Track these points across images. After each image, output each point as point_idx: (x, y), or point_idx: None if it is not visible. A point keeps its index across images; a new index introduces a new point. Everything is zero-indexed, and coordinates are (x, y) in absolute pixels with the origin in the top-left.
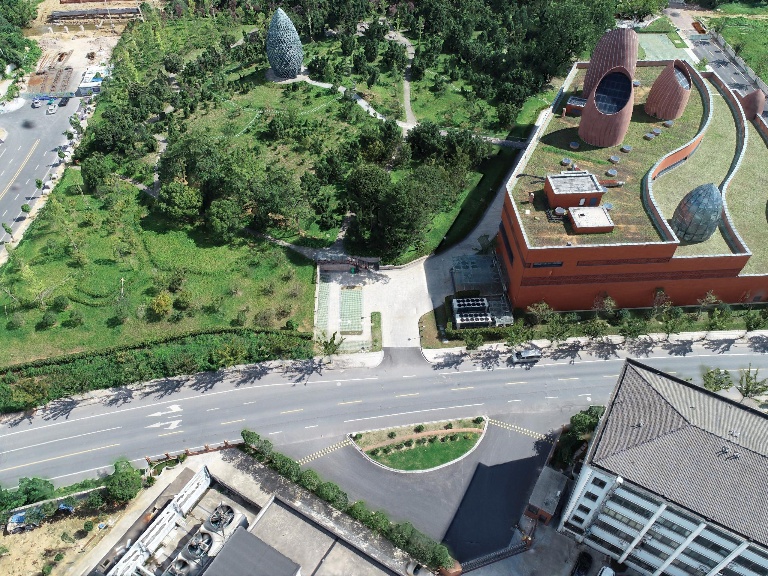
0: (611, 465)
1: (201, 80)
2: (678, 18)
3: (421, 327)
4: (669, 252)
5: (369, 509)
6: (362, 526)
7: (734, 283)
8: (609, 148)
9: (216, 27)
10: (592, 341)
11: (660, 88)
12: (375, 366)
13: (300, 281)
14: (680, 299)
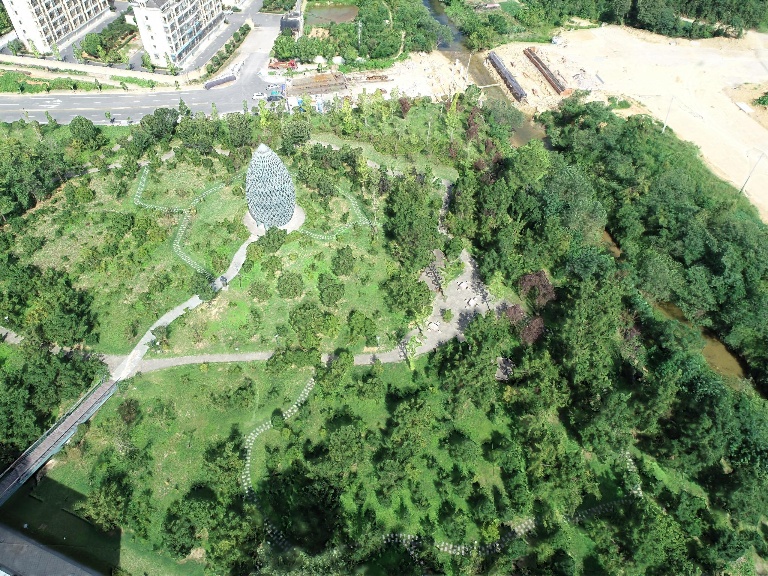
0: None
1: None
2: None
3: None
4: None
5: None
6: None
7: None
8: None
9: None
10: None
11: None
12: None
13: None
14: None
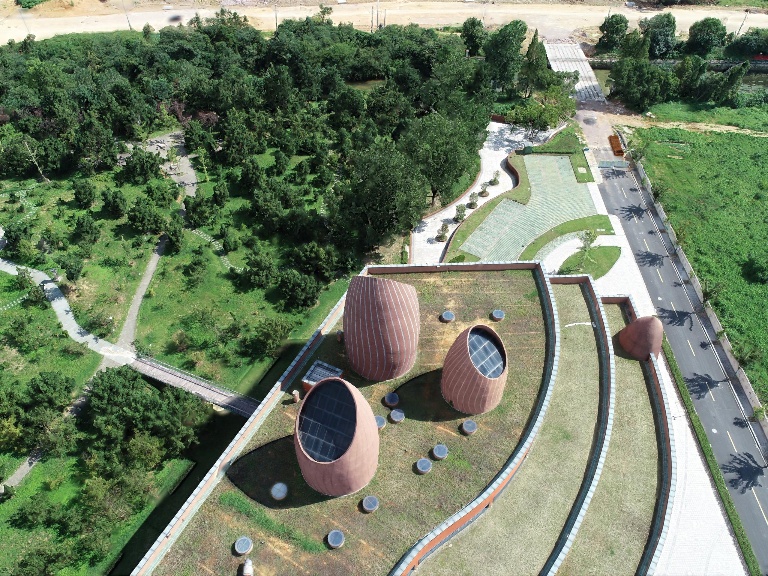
0: None
1: None
2: (592, 127)
3: None
4: None
5: None
6: None
7: None
8: (340, 499)
9: None
10: None
11: (451, 369)
12: None
13: None
14: None
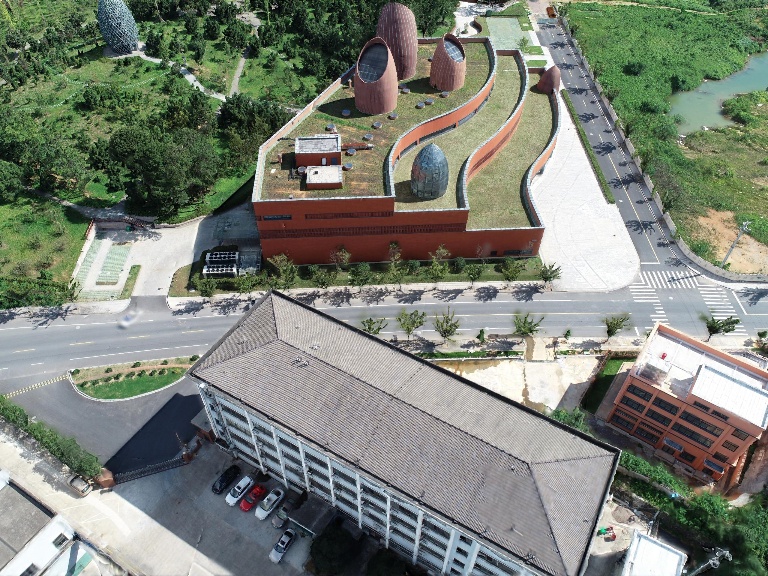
0: (206, 375)
1: (42, 55)
2: (535, 3)
3: (174, 278)
4: (389, 206)
5: (59, 432)
6: (39, 444)
7: (465, 238)
8: (378, 115)
9: (75, 6)
10: (331, 291)
11: (435, 60)
12: (118, 312)
13: (71, 237)
14: (420, 253)
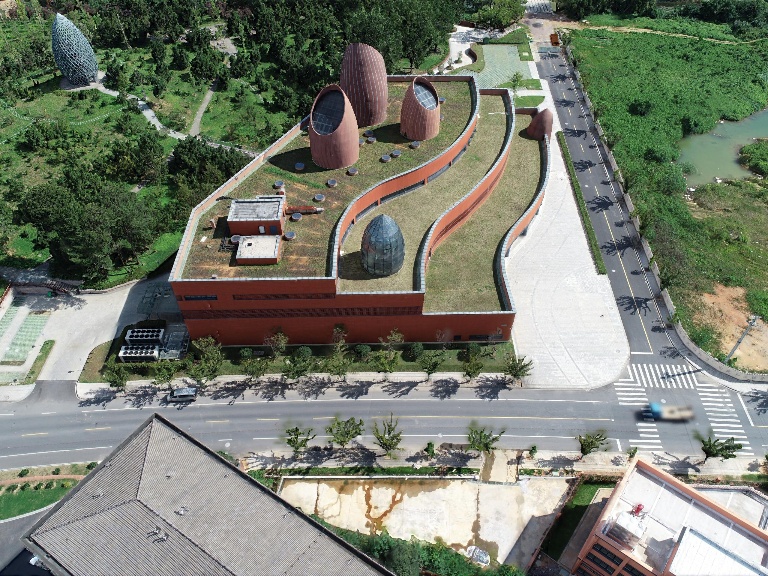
0: (46, 541)
1: None
2: (539, 29)
3: (89, 358)
4: (330, 288)
5: None
6: None
7: (422, 321)
8: (335, 170)
9: (43, 30)
10: (264, 379)
11: (404, 107)
12: (18, 400)
13: None
14: (371, 336)
